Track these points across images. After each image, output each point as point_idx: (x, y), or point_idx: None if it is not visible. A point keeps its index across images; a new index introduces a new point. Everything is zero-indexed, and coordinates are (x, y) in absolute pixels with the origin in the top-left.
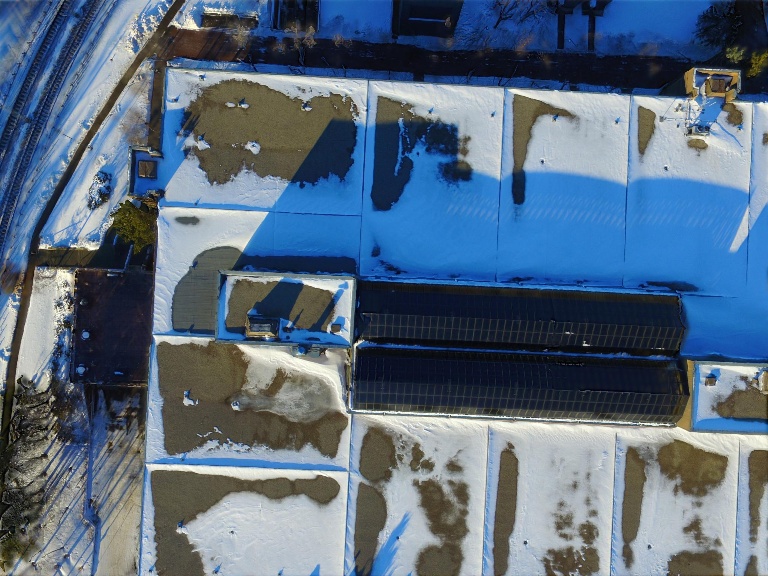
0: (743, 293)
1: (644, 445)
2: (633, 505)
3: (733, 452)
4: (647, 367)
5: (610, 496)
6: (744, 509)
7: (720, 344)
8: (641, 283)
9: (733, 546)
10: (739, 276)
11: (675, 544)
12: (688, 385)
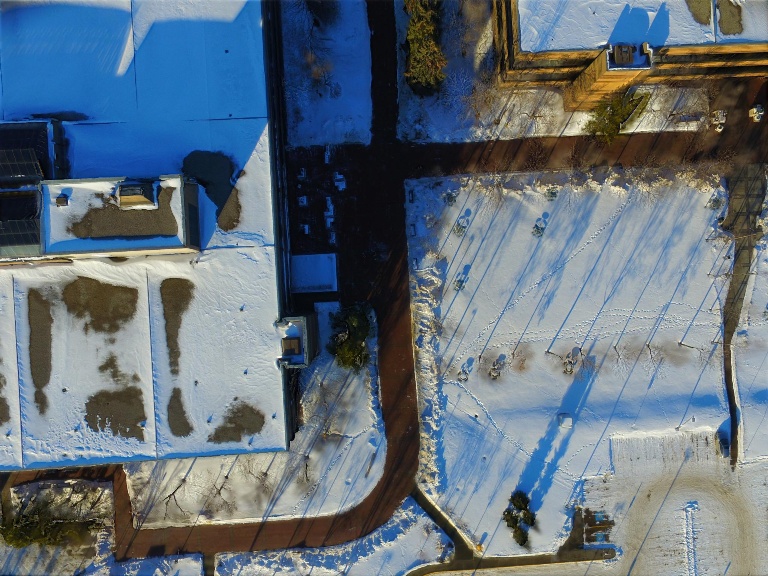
0: (135, 117)
1: (46, 285)
2: (41, 348)
3: (141, 283)
4: (12, 197)
5: (13, 341)
6: (160, 341)
7: (118, 173)
8: (25, 116)
9: (151, 380)
10: (130, 100)
11: (92, 384)
12: (41, 208)
